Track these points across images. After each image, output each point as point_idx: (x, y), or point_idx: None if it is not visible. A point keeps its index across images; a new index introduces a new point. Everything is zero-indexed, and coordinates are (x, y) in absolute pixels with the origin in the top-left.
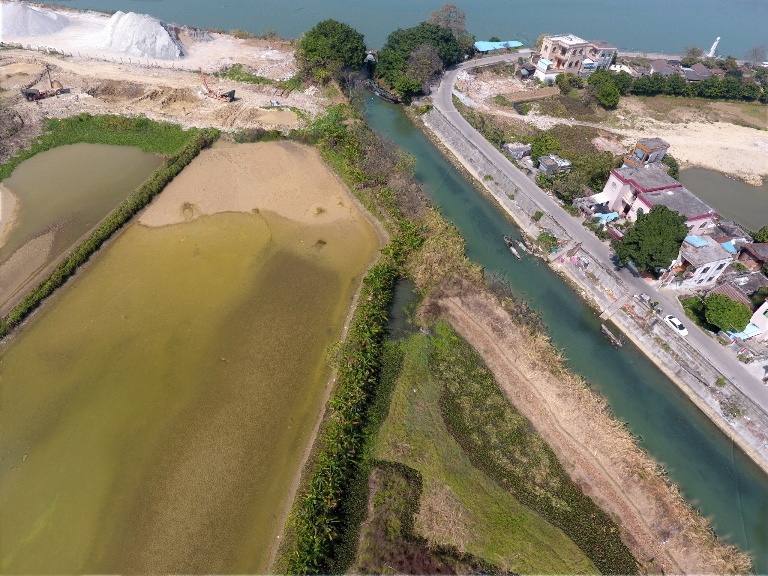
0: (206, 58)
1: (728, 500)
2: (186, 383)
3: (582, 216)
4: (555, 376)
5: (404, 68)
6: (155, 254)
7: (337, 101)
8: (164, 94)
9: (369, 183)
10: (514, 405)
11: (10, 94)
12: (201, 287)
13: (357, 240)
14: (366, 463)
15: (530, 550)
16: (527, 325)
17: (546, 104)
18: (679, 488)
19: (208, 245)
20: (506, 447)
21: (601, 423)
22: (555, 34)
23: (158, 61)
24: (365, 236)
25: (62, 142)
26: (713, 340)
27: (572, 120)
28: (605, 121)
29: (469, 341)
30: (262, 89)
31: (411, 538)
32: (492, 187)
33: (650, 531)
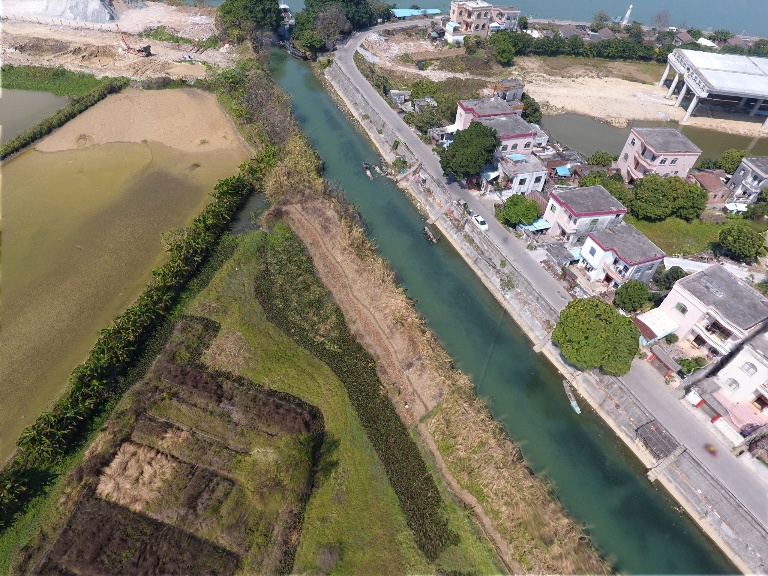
0: (135, 22)
1: (482, 348)
2: (41, 262)
3: (434, 144)
4: (359, 258)
5: (313, 28)
6: (42, 172)
7: (246, 56)
8: (87, 50)
9: (254, 120)
10: (322, 282)
11: None
12: (76, 196)
13: (229, 164)
14: (176, 317)
15: (292, 374)
16: (345, 219)
17: (447, 61)
18: (437, 336)
19: (92, 166)
20: (302, 309)
21: (384, 290)
22: None
23: (89, 24)
24: (238, 161)
25: None
26: (510, 234)
27: (467, 74)
28: (498, 76)
29: (300, 237)
30: (180, 47)
31: (195, 365)
32: (367, 125)
33: (399, 364)
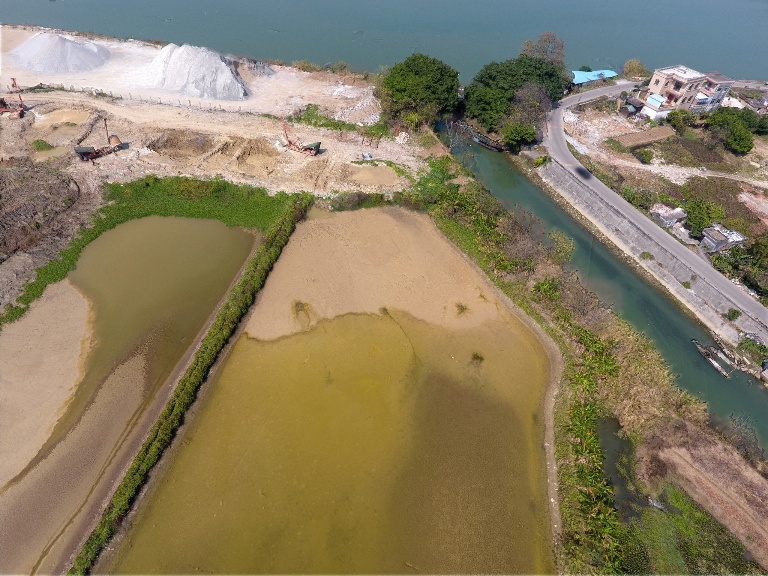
0: (272, 97)
1: None
2: None
3: None
4: None
5: (507, 110)
6: (278, 385)
7: (437, 152)
8: (236, 146)
9: None
10: None
11: (60, 152)
12: (349, 437)
13: (519, 352)
14: None
15: None
16: None
17: (668, 150)
18: None
19: (340, 367)
20: None
21: None
22: (666, 66)
23: (220, 102)
24: (527, 346)
25: (129, 215)
26: None
27: (704, 170)
28: (740, 170)
29: (719, 519)
30: (346, 137)
31: None
32: (655, 269)
33: None
